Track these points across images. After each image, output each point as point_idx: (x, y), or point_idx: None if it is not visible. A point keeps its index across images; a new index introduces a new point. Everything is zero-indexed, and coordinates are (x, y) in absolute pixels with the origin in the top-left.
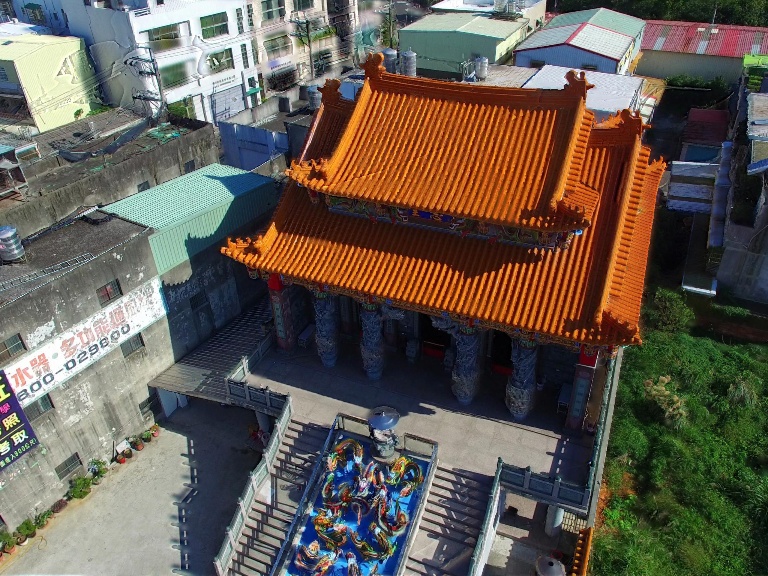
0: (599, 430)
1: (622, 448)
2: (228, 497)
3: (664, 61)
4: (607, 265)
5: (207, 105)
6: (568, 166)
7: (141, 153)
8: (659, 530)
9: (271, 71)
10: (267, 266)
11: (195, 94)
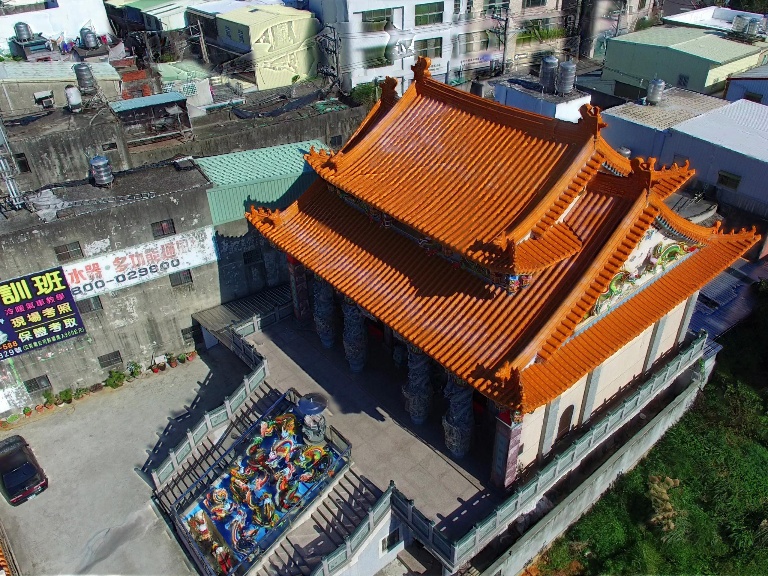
0: (513, 496)
1: (583, 534)
2: None
3: None
4: None
5: (406, 88)
6: (546, 207)
7: (291, 120)
8: None
9: (460, 64)
10: (273, 238)
11: (397, 76)
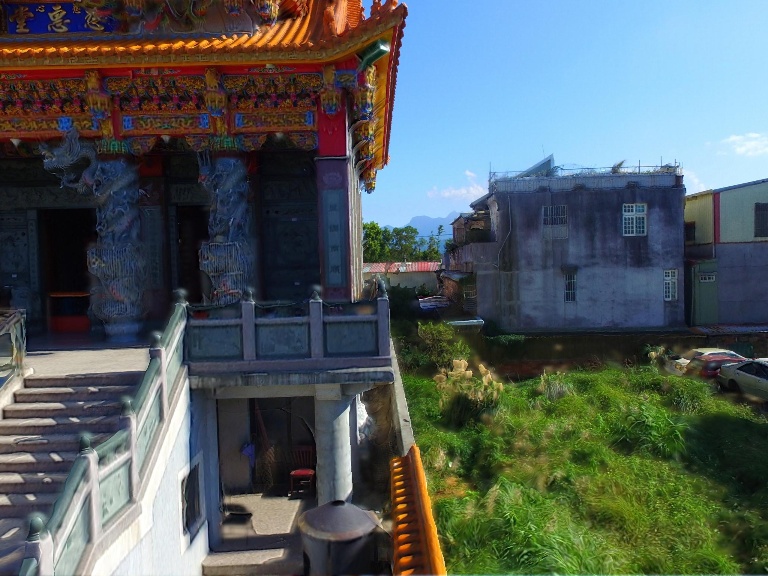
0: None
1: (431, 443)
2: None
3: None
4: None
5: None
6: None
7: None
8: None
9: None
10: None
11: None
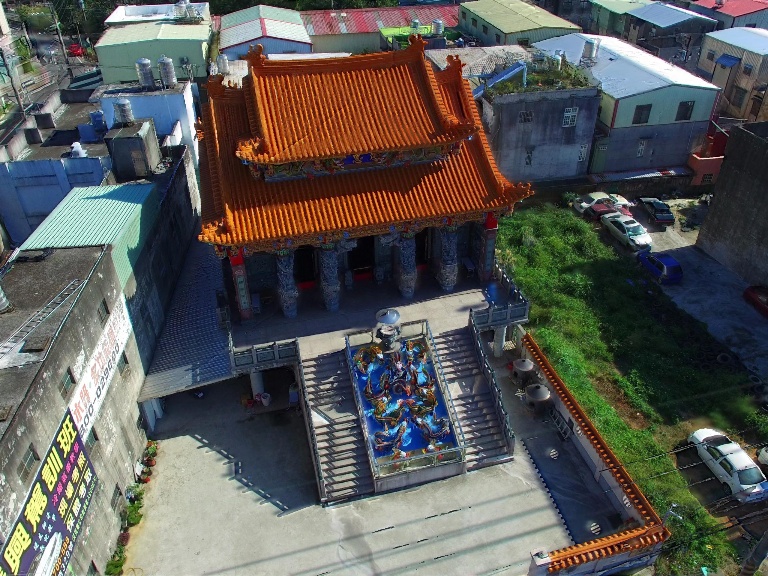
0: None
1: None
2: (271, 452)
3: (320, 43)
4: (486, 157)
5: None
6: None
7: None
8: (548, 326)
9: None
10: (245, 238)
11: None
